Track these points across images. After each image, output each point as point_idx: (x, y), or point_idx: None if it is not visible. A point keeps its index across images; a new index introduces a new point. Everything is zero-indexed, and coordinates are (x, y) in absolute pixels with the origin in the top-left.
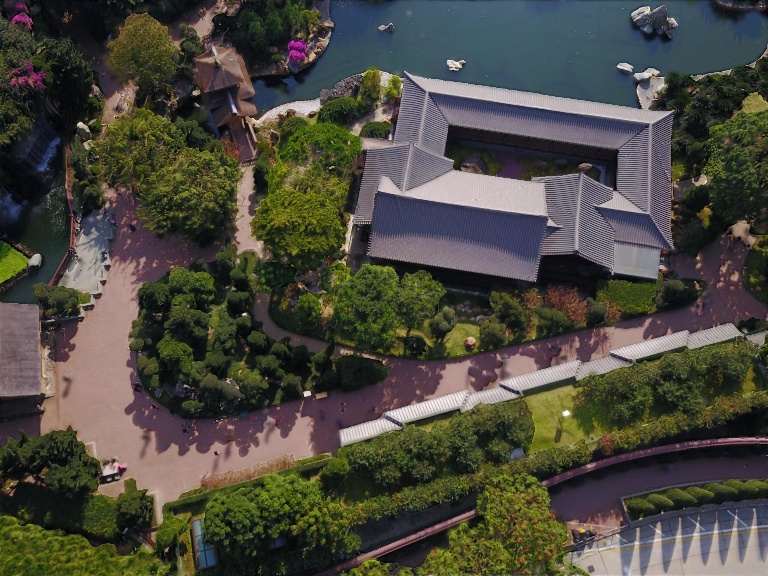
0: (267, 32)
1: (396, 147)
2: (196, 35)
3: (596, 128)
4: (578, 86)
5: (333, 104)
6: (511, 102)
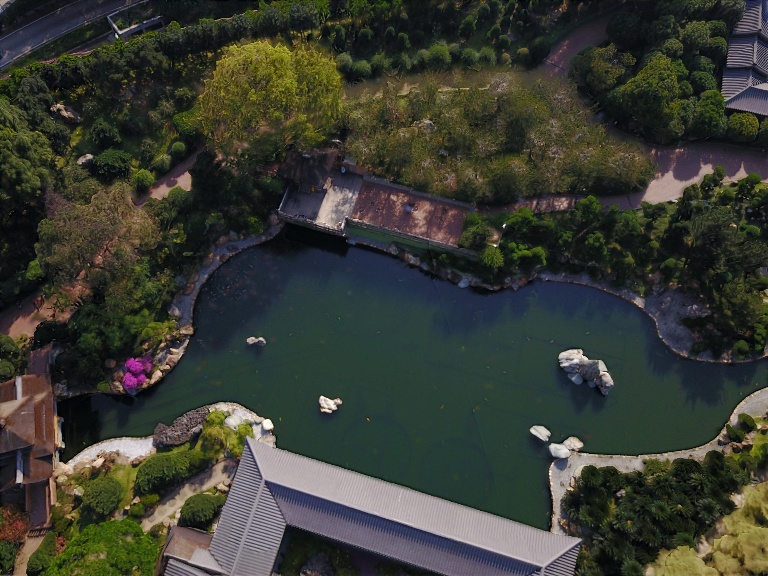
0: (104, 343)
1: (197, 575)
2: (11, 348)
3: (472, 559)
4: (479, 448)
5: (153, 467)
6: (367, 509)
